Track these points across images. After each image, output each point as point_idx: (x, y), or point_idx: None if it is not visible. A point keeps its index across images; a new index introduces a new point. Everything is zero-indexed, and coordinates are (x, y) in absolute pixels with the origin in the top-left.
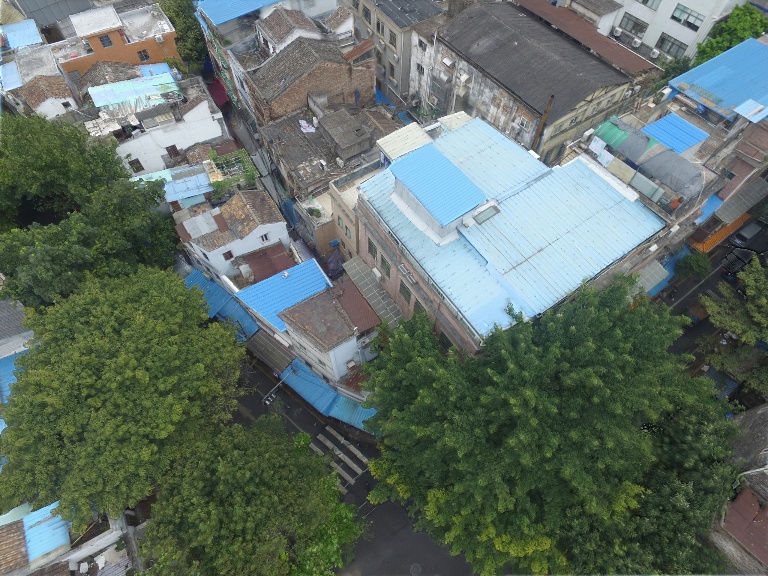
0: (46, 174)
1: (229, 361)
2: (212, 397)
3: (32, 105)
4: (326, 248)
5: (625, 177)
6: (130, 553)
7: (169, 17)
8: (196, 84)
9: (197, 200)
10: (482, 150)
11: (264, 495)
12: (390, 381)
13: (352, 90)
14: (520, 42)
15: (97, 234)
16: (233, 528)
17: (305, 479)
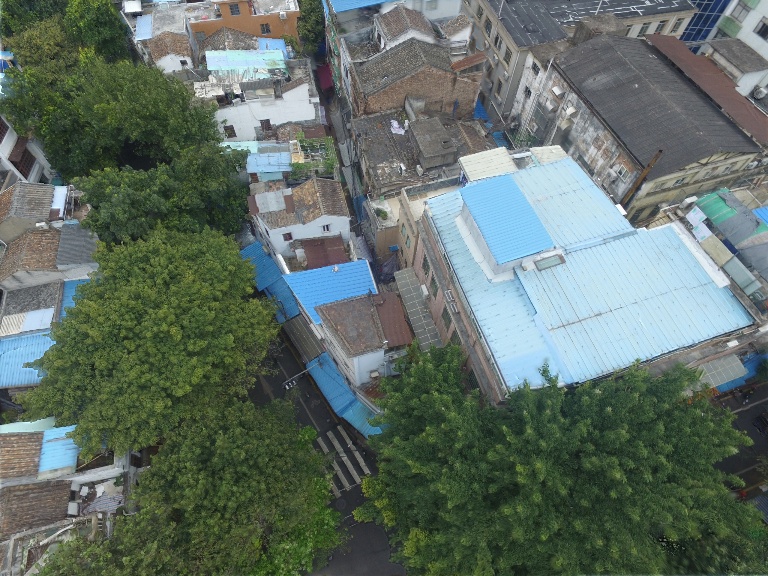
0: (148, 123)
1: (259, 339)
2: (235, 369)
3: (155, 57)
4: (385, 251)
5: (719, 258)
6: (125, 492)
7: None
8: (304, 65)
9: (275, 176)
10: (565, 192)
11: (253, 479)
12: (402, 406)
13: (452, 100)
14: (641, 85)
15: (177, 188)
16: (216, 502)
17: (298, 474)
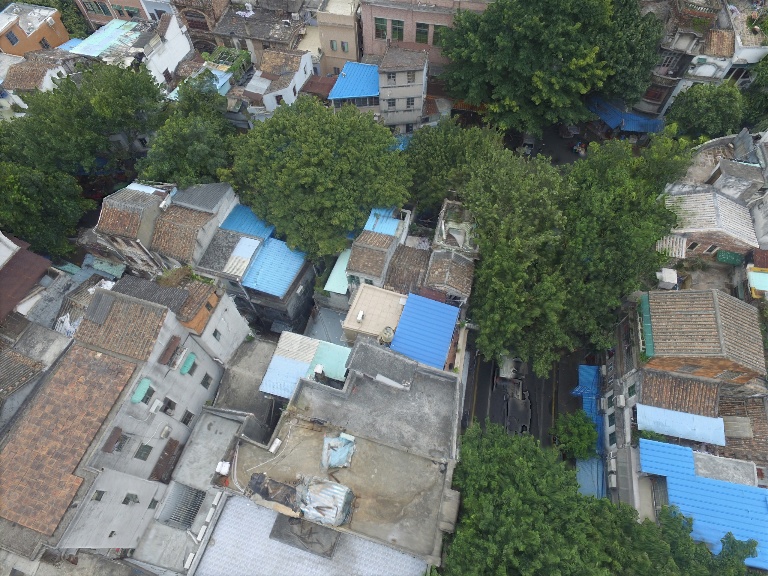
0: None
1: None
2: None
3: (35, 85)
4: None
5: None
6: None
7: (37, 5)
8: None
9: (226, 88)
10: None
11: None
12: None
13: None
14: None
15: None
16: None
17: None
